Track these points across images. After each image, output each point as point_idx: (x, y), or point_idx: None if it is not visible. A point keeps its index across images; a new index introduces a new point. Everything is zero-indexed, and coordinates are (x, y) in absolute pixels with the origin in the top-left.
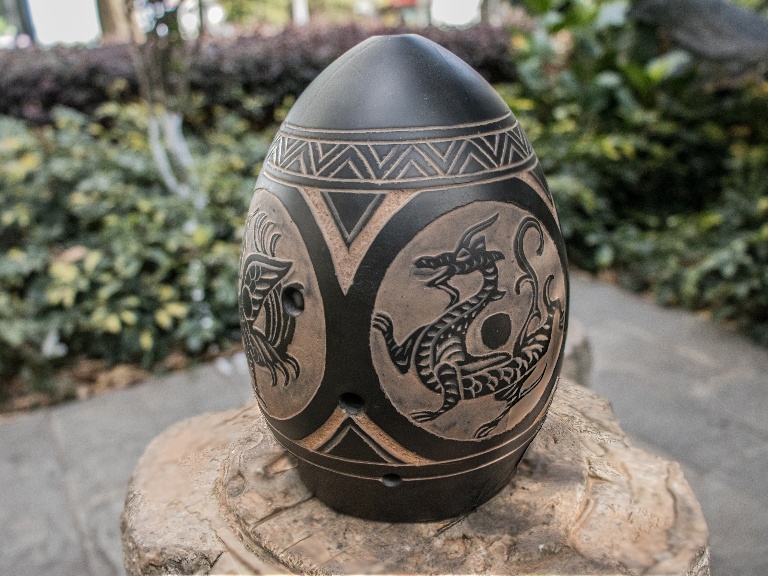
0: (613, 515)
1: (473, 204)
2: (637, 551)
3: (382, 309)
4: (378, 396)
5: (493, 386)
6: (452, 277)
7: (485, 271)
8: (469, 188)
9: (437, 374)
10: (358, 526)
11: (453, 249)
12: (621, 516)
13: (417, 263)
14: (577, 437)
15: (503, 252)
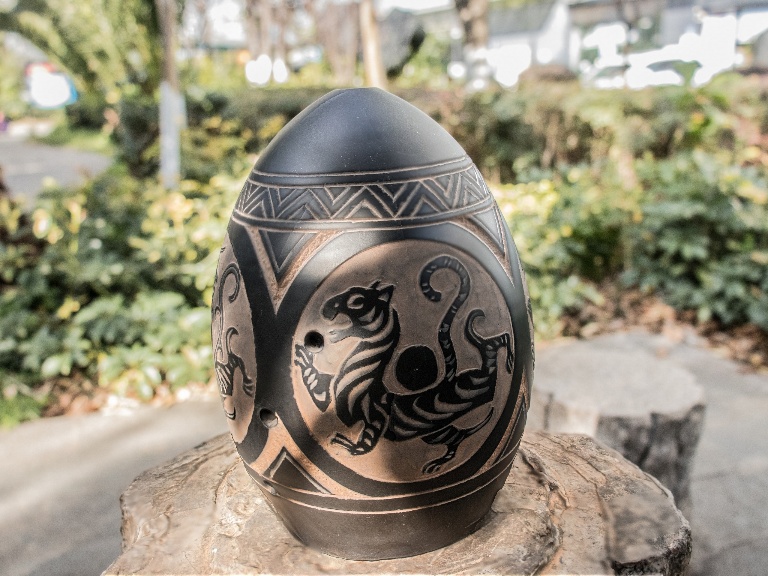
0: None
1: None
2: None
3: None
4: None
5: None
6: None
7: None
8: None
9: None
10: None
11: None
12: None
13: None
14: None
15: None
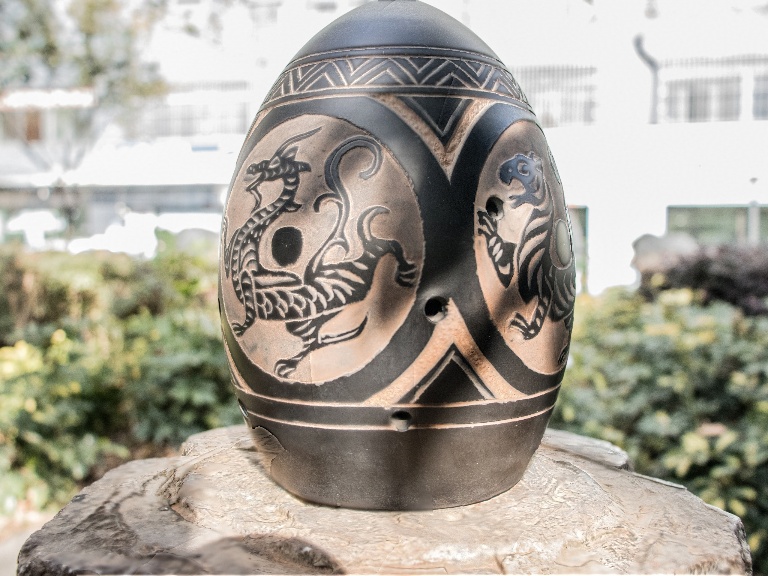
0: None
1: (302, 117)
2: None
3: None
4: None
5: (284, 312)
6: (262, 183)
7: (287, 180)
8: (305, 102)
9: (241, 282)
10: (260, 475)
11: (271, 157)
12: None
13: (248, 170)
14: (572, 538)
15: (312, 165)
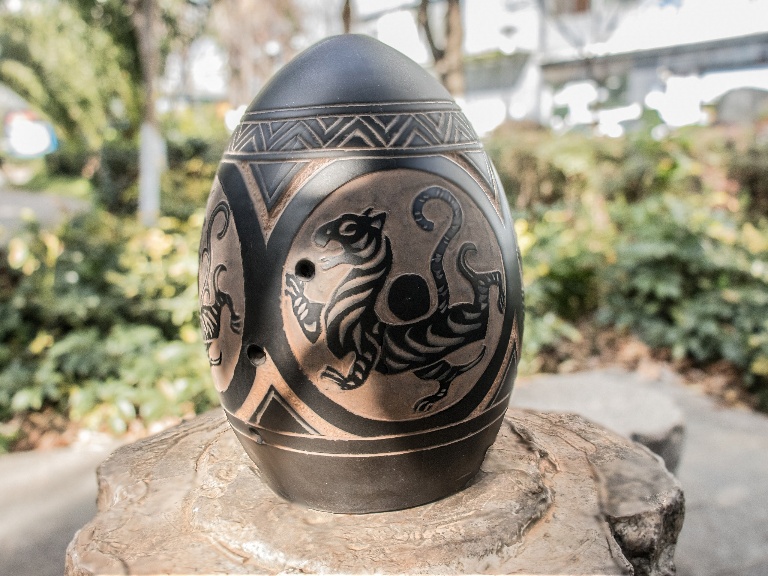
0: (211, 569)
1: None
2: (152, 568)
3: None
4: None
5: None
6: None
7: None
8: None
9: None
10: None
11: None
12: (206, 574)
13: None
14: (364, 575)
15: None
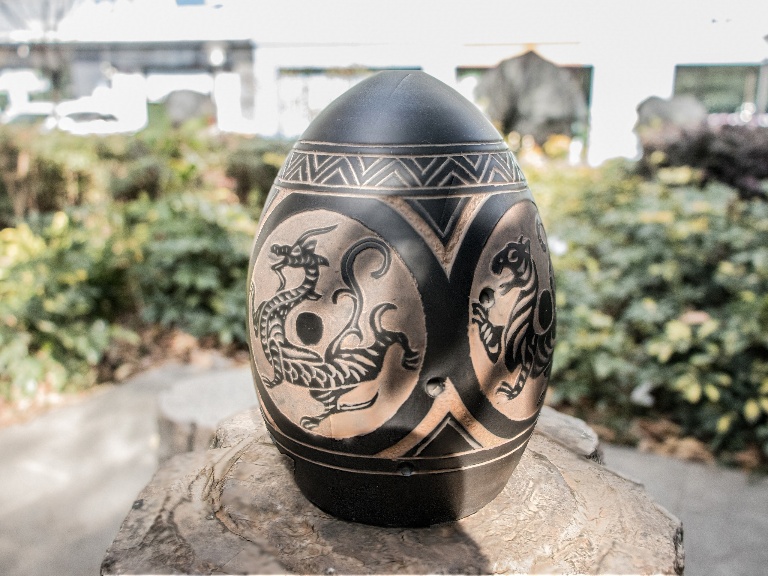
0: None
1: (319, 211)
2: None
3: (254, 279)
4: (251, 351)
5: (308, 381)
6: (285, 267)
7: (308, 270)
8: (322, 197)
9: (269, 347)
10: (286, 478)
11: (293, 244)
12: None
13: (272, 248)
14: (541, 554)
15: (330, 260)
